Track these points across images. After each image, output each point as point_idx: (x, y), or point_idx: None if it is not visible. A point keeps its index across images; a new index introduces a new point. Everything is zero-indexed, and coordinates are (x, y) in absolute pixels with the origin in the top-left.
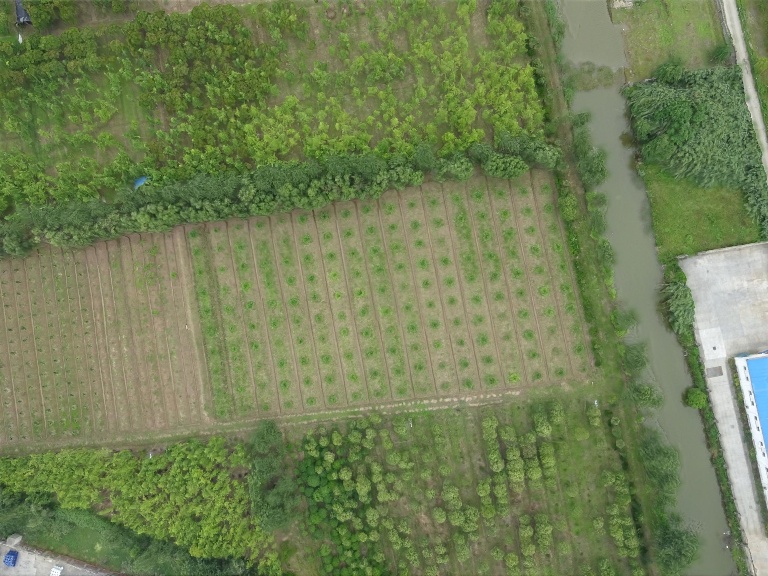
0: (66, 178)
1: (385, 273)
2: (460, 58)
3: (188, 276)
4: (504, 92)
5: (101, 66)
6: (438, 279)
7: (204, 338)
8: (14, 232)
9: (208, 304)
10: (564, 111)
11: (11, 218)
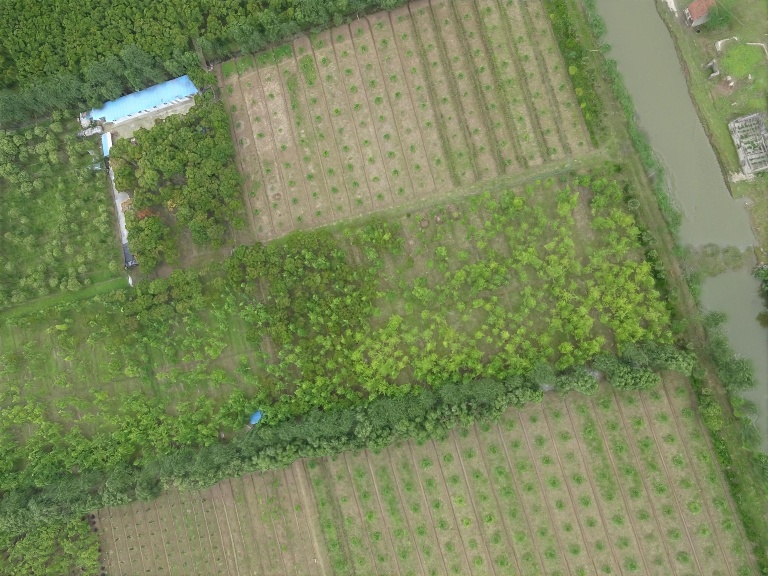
0: (186, 420)
1: (513, 494)
2: (568, 261)
3: (311, 507)
4: (621, 294)
5: (207, 304)
6: (572, 498)
7: (334, 572)
8: (144, 480)
9: (334, 536)
10: (690, 302)
11: (139, 463)
